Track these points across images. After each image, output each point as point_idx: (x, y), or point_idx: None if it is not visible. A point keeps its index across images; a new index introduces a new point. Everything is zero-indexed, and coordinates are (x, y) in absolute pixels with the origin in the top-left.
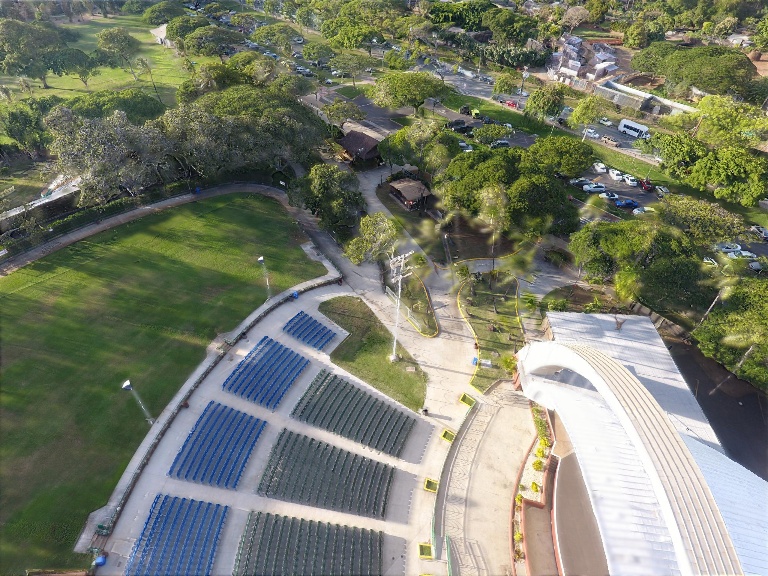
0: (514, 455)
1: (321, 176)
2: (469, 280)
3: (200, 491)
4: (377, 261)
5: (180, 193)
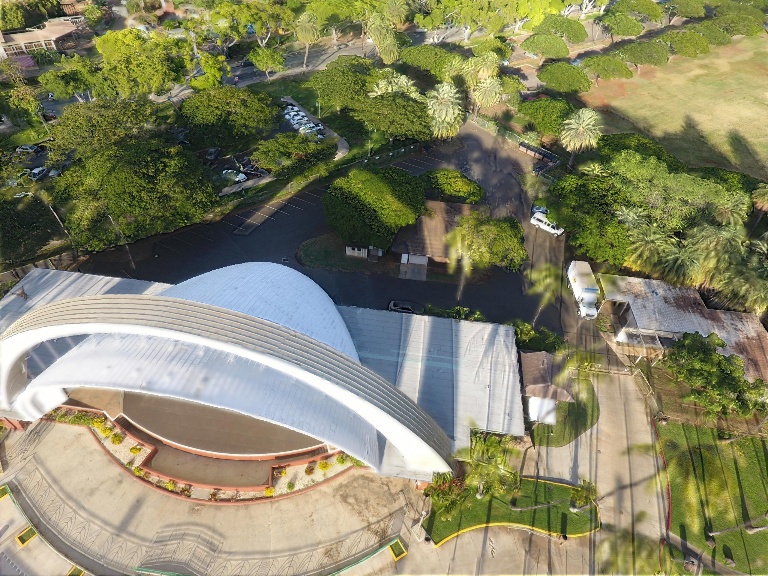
0: (94, 460)
1: None
2: None
3: None
4: None
5: None
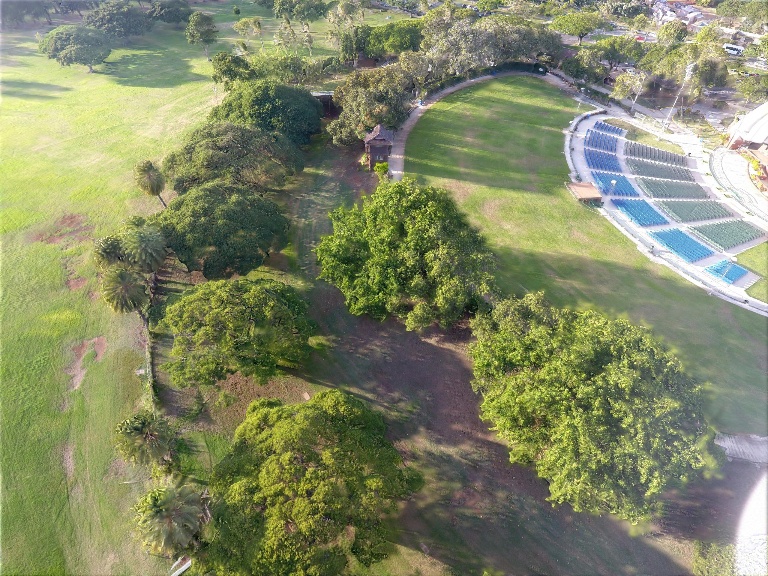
0: (741, 168)
1: (590, 54)
2: (678, 112)
3: (606, 172)
4: (619, 105)
5: (484, 74)
